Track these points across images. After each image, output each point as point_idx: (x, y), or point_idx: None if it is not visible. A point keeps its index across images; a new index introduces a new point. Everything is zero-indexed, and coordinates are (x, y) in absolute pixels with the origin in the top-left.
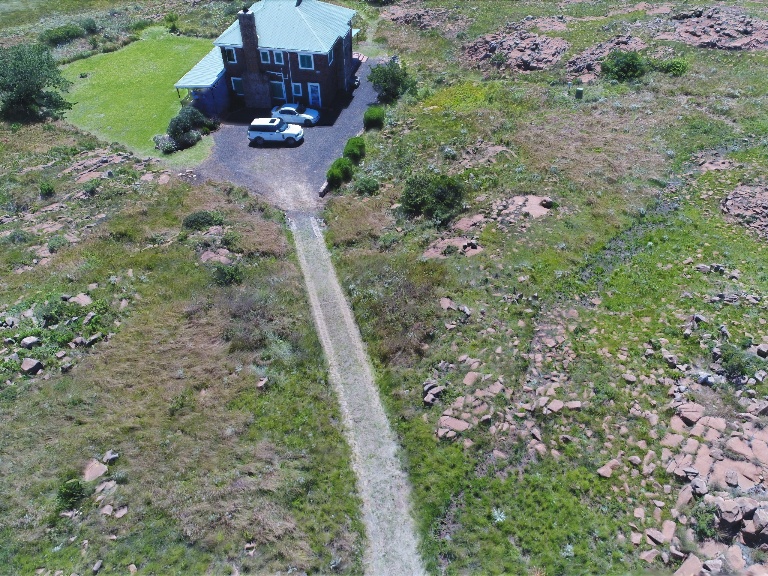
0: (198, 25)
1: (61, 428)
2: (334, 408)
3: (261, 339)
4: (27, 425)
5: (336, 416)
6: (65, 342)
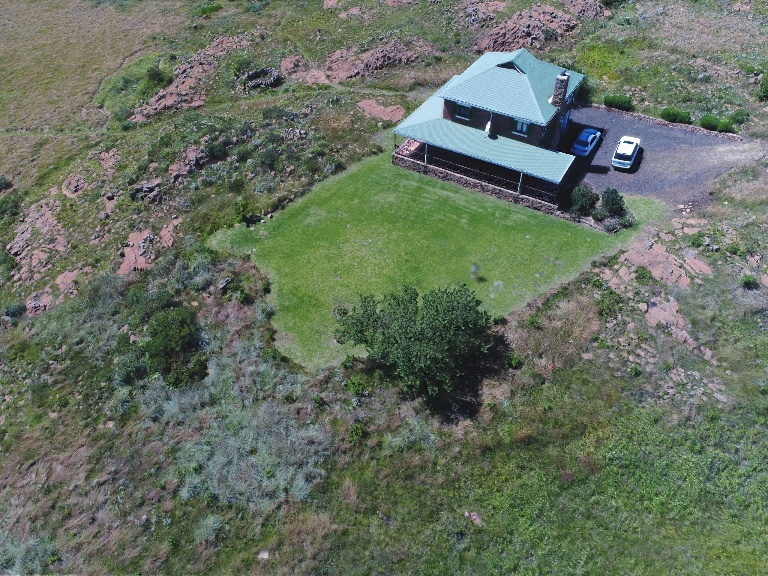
0: (261, 195)
1: None
2: None
3: None
4: None
5: None
6: None
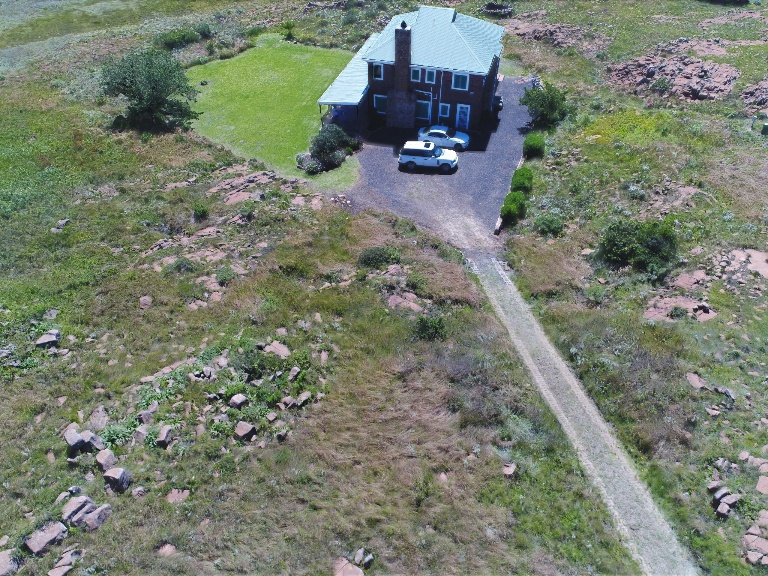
0: (315, 33)
1: (294, 513)
2: (601, 509)
3: (496, 414)
4: (257, 507)
5: (606, 520)
6: (274, 402)
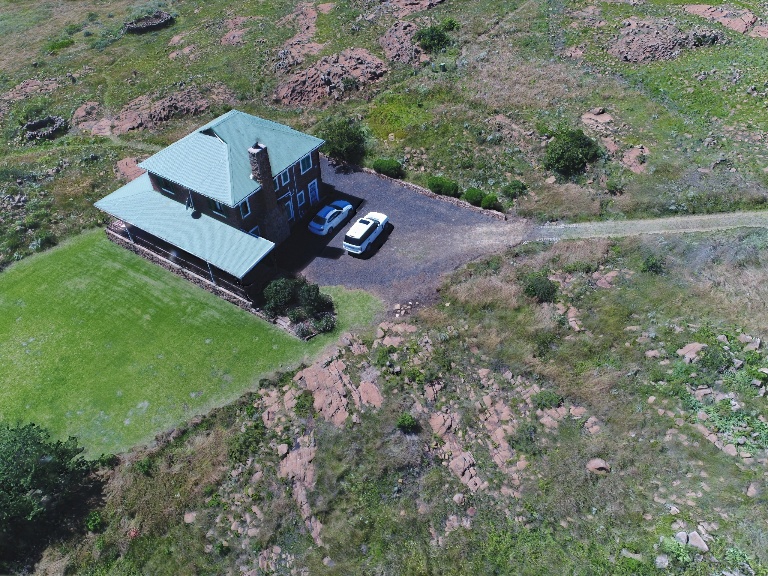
0: None
1: None
2: None
3: None
4: None
5: None
6: None
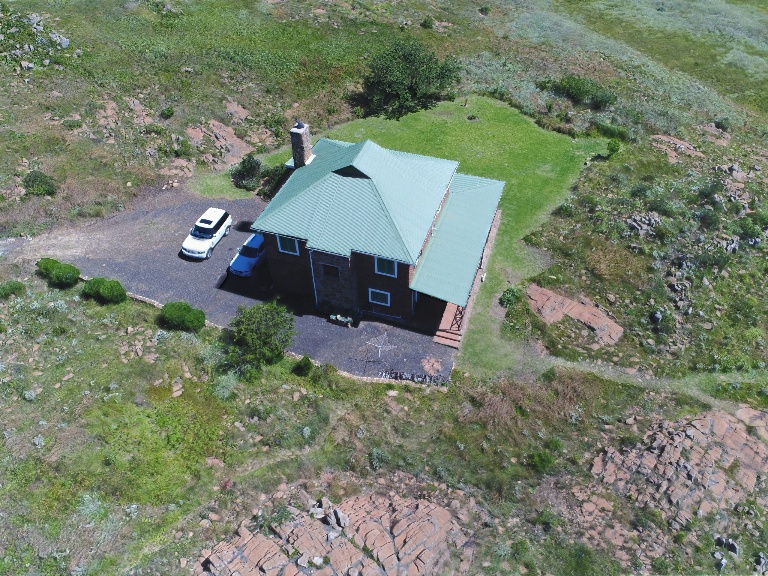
0: None
1: None
2: None
3: None
4: None
5: None
6: None
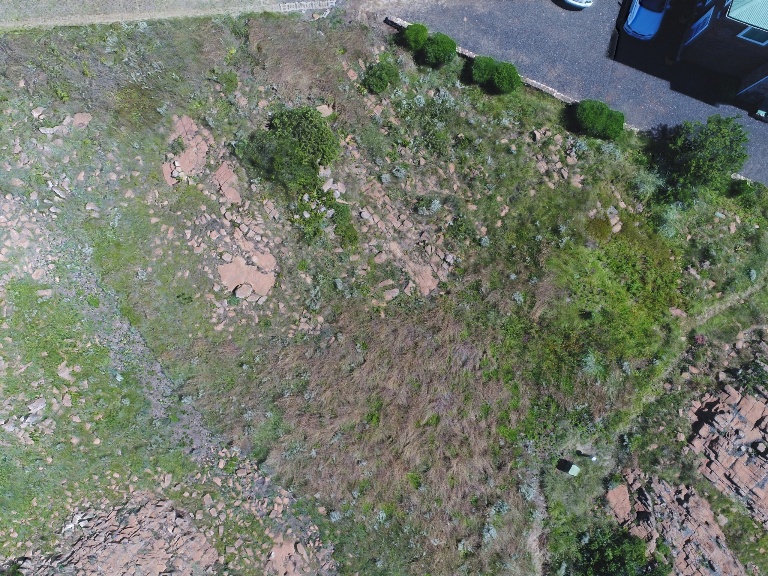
0: None
1: None
2: None
3: None
4: None
5: None
6: None
